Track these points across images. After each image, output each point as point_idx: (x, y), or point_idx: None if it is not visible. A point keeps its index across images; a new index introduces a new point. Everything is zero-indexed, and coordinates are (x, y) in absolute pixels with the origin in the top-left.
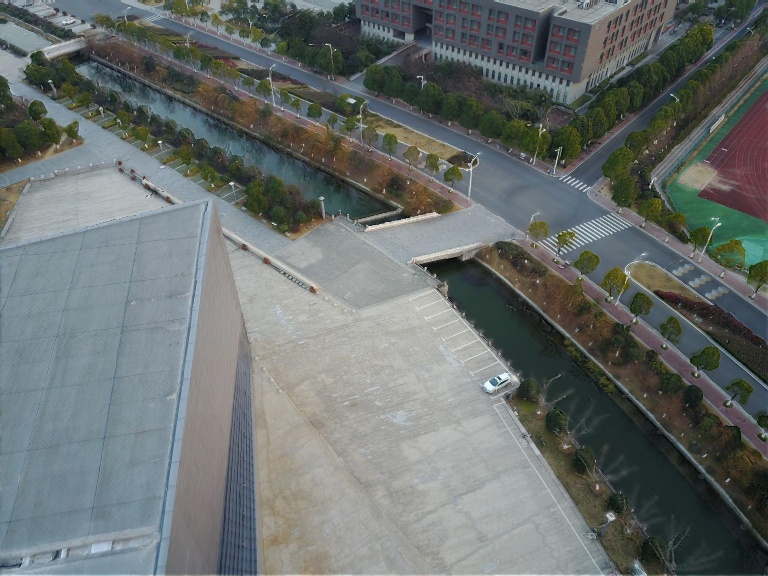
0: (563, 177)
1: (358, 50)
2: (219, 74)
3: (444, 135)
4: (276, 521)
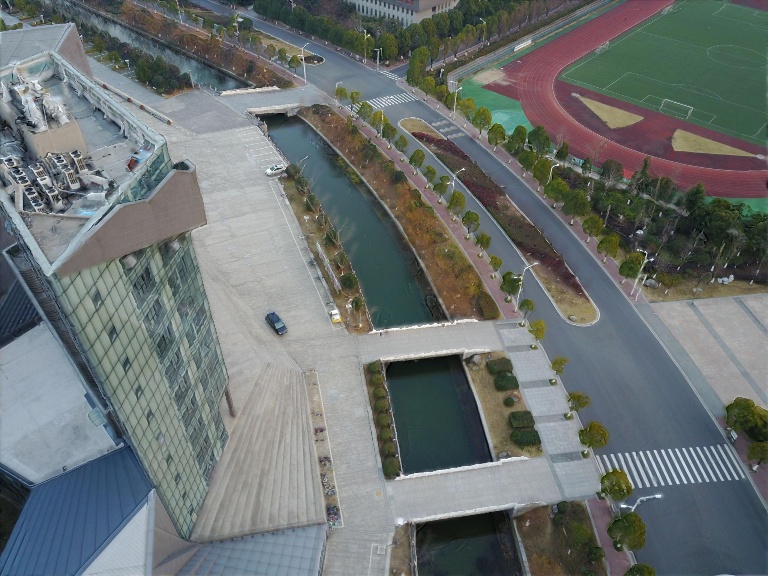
0: (384, 72)
1: None
2: (142, 0)
3: None
4: None
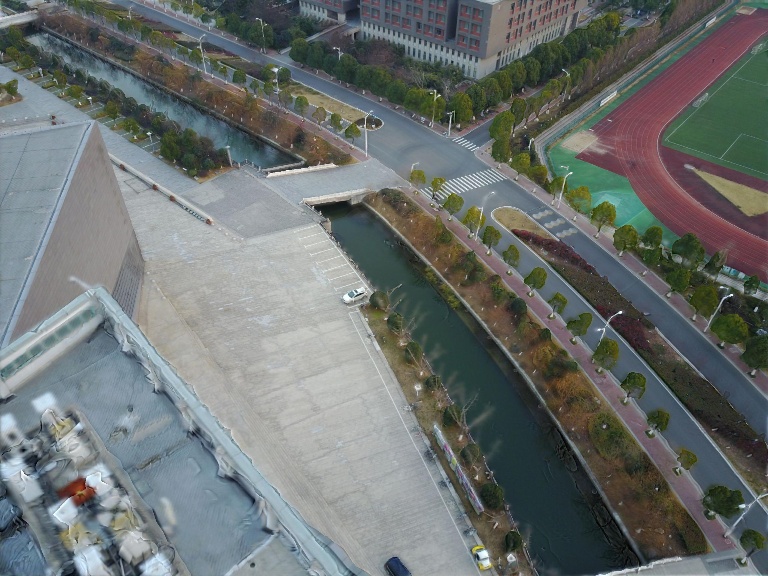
0: (456, 138)
1: (290, 27)
2: (158, 44)
3: (357, 102)
4: None
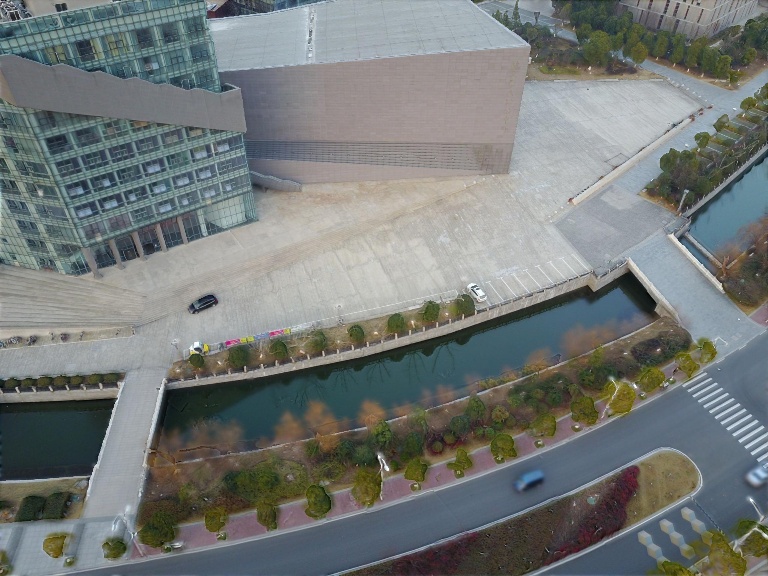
0: None
1: None
2: None
3: None
4: (373, 185)
